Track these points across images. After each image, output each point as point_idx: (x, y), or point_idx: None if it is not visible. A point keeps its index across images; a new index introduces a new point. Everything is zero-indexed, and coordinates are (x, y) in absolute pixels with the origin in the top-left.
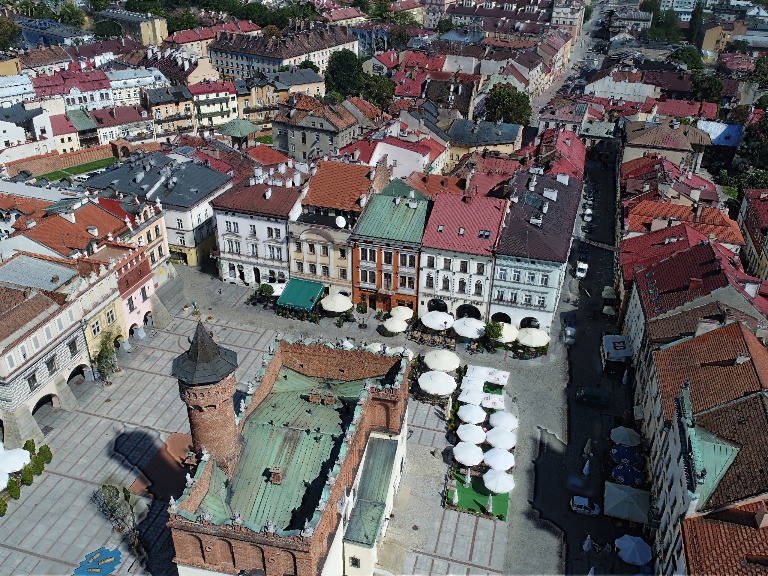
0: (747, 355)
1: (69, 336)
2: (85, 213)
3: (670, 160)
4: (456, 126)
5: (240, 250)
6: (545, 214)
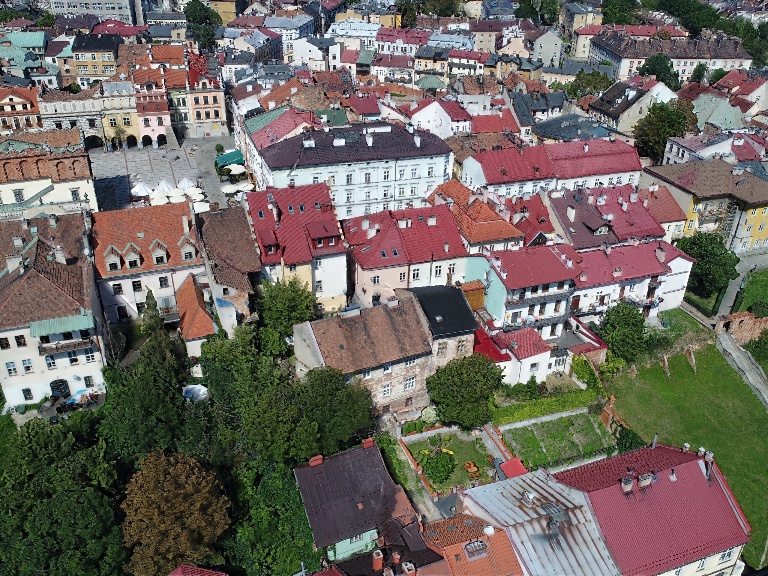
0: (133, 204)
1: (90, 116)
2: (176, 72)
3: (676, 200)
4: (559, 118)
5: (235, 124)
6: (334, 146)
